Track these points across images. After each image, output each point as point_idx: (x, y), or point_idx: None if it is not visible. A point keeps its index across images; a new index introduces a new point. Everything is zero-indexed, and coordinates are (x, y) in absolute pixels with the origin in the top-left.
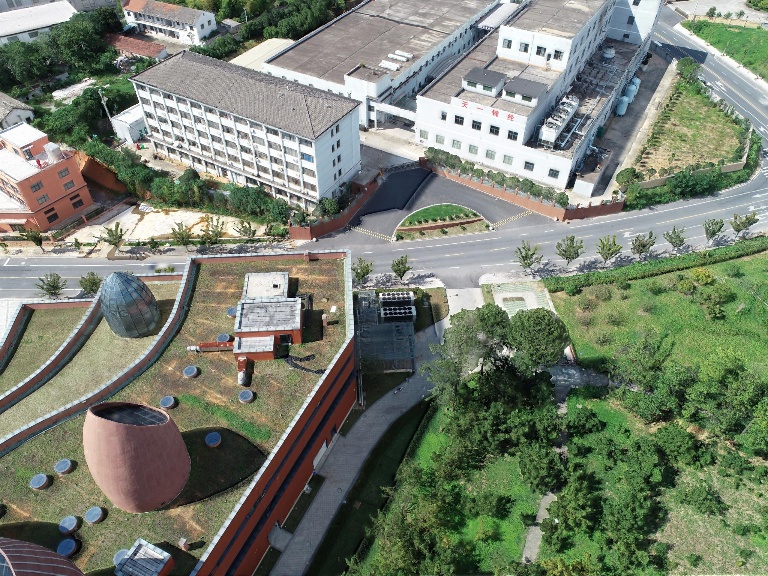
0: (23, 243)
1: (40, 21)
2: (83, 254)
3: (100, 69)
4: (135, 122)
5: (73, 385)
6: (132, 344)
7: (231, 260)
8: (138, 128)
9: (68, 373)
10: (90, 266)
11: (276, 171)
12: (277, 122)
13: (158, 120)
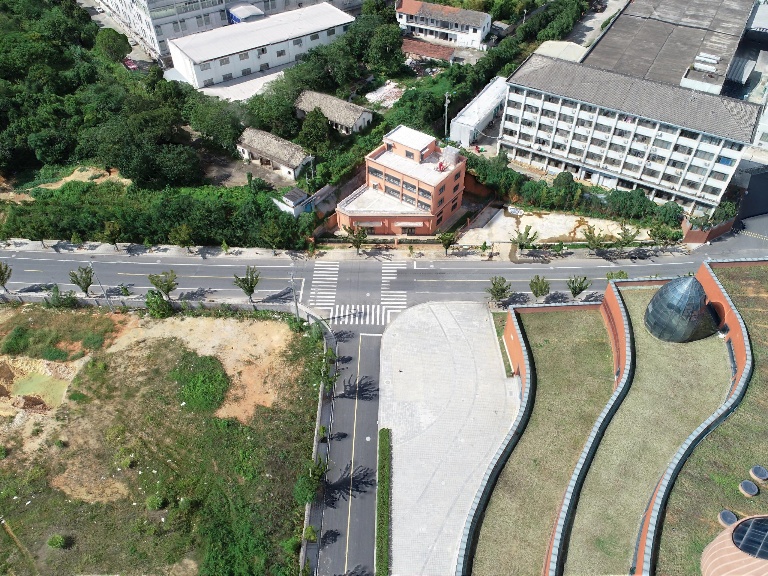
0: (419, 246)
1: (317, 24)
2: (486, 257)
3: (395, 72)
4: (477, 125)
5: (659, 390)
6: (683, 349)
7: (741, 264)
8: (474, 131)
9: (644, 378)
10: (500, 269)
11: (669, 174)
12: (698, 125)
13: (520, 123)
